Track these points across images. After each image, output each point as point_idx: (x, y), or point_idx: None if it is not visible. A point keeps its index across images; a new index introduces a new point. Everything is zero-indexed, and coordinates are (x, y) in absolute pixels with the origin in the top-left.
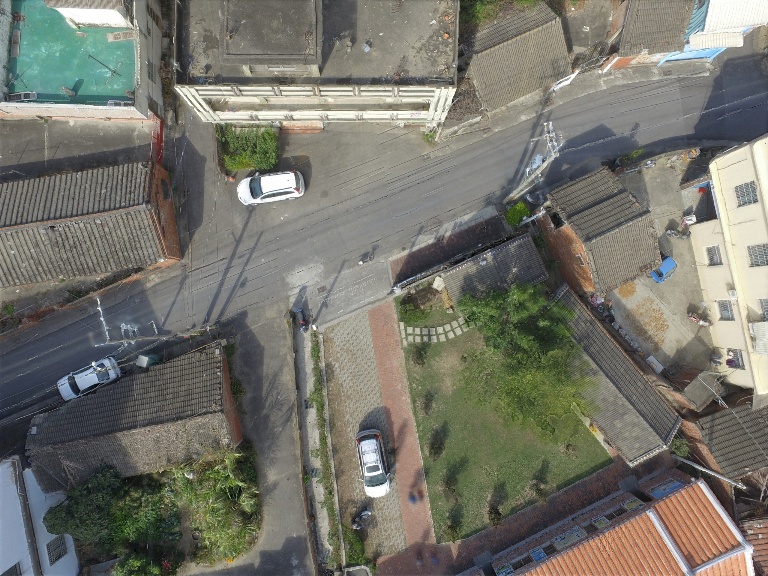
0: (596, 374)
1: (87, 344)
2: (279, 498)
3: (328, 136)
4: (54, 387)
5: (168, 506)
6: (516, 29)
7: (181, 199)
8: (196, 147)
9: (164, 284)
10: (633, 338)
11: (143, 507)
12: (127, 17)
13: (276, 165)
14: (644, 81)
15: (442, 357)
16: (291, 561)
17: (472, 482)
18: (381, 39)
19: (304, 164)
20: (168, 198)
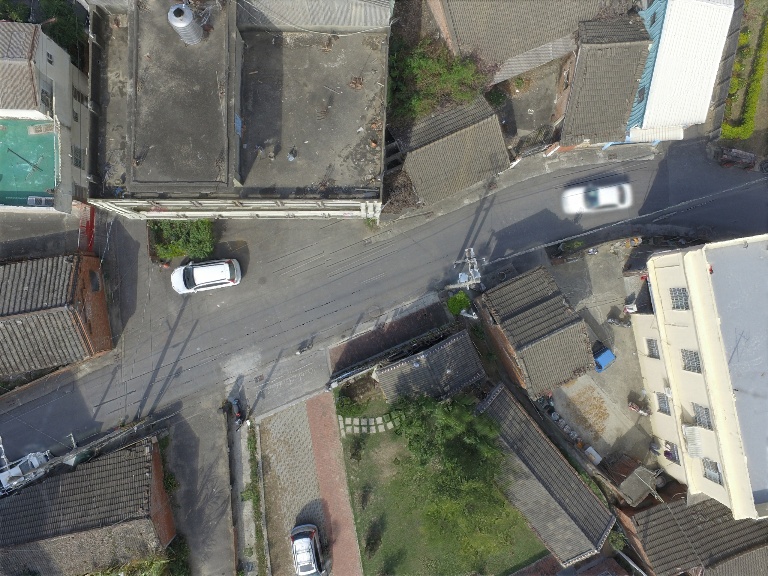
0: (529, 478)
1: (15, 437)
2: None
3: (266, 221)
4: None
5: None
6: (452, 124)
7: (113, 286)
8: (129, 232)
9: (95, 374)
10: (573, 427)
11: None
12: (46, 112)
13: (211, 252)
14: (589, 165)
15: (381, 448)
16: None
17: (410, 574)
18: (306, 147)
19: (241, 249)
20: (97, 290)
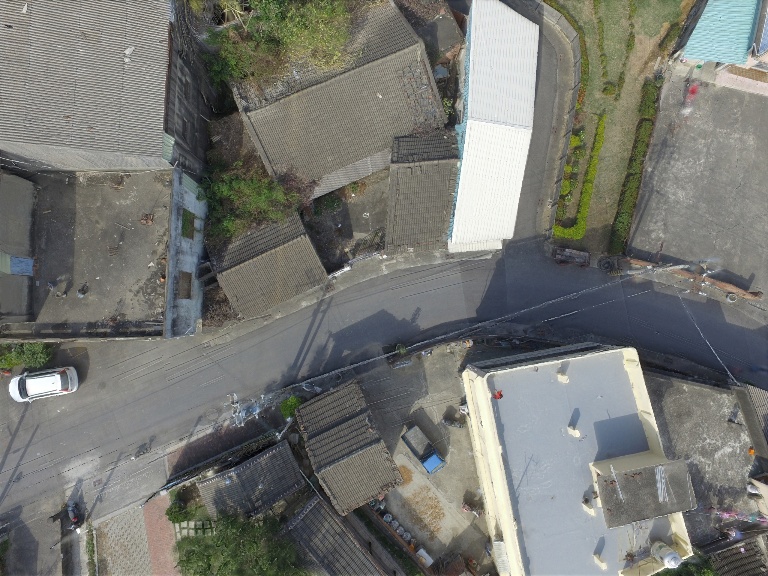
0: None
1: None
2: None
3: None
4: None
5: None
6: (265, 243)
7: None
8: None
9: None
10: (408, 527)
11: None
12: None
13: (49, 361)
14: (426, 265)
15: (216, 550)
16: None
17: None
18: (98, 283)
19: (82, 356)
20: None
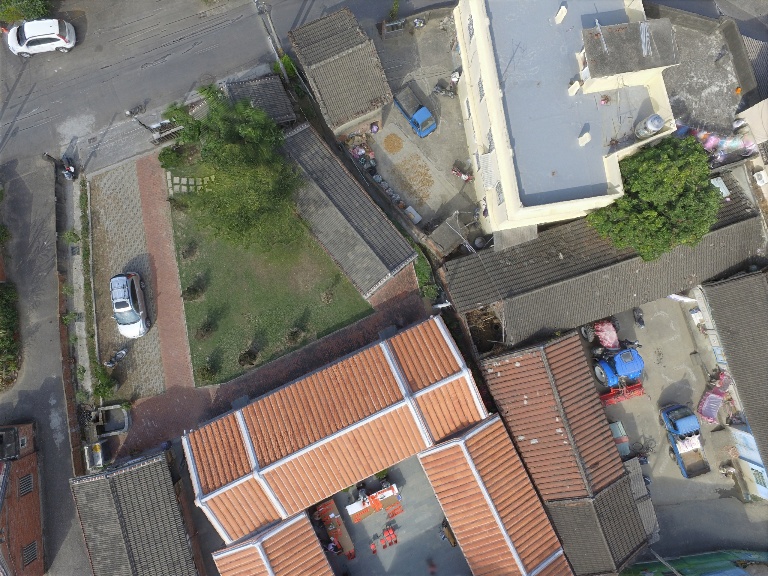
0: (327, 205)
1: None
2: (40, 340)
3: None
4: None
5: None
6: None
7: None
8: None
9: None
10: (398, 192)
11: None
12: None
13: (47, 16)
14: None
15: None
16: (49, 401)
17: (233, 328)
18: None
19: (80, 19)
20: None
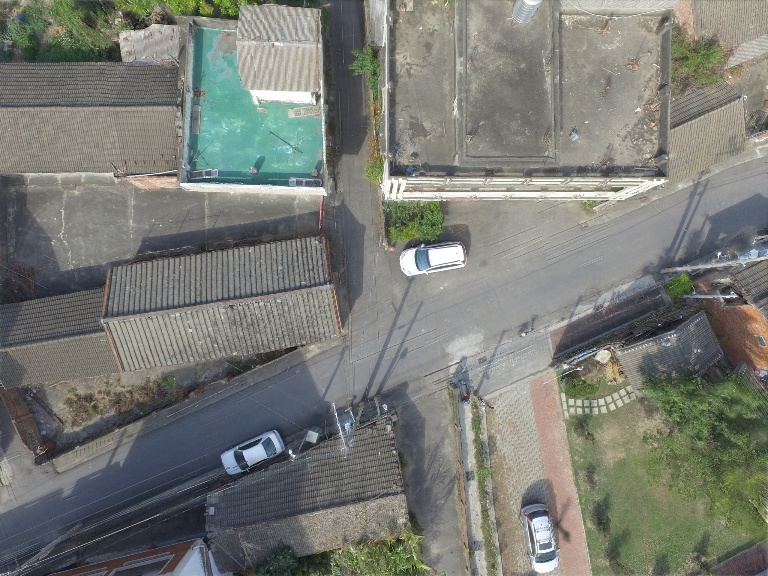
0: None
1: (248, 416)
2: None
3: (487, 204)
4: (216, 459)
5: None
6: (697, 107)
7: (340, 268)
8: (355, 215)
9: (324, 355)
10: None
11: None
12: (313, 95)
13: None
14: None
15: (604, 429)
16: None
17: (634, 555)
18: (586, 127)
19: (463, 233)
20: (336, 271)
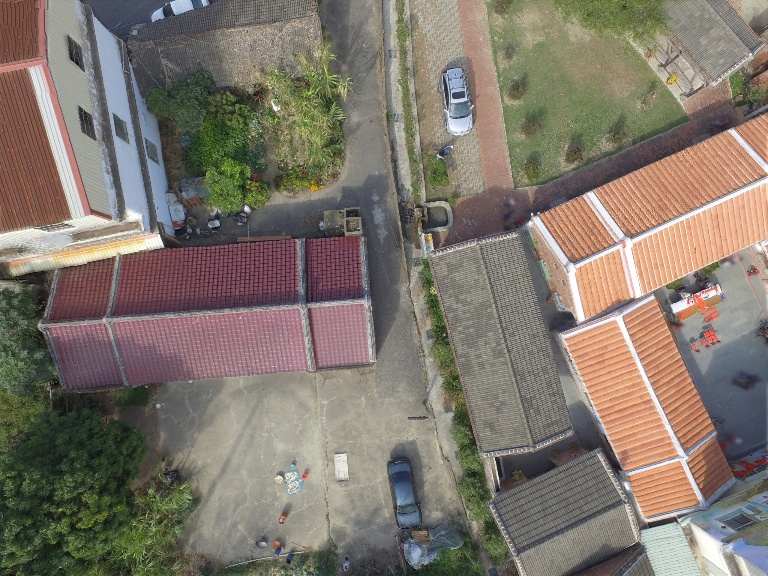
0: None
1: None
2: (362, 138)
3: None
4: None
5: (255, 137)
6: None
7: None
8: None
9: None
10: None
11: (237, 114)
12: None
13: None
14: None
15: (524, 13)
16: (372, 197)
17: (550, 132)
18: None
19: None
20: None
